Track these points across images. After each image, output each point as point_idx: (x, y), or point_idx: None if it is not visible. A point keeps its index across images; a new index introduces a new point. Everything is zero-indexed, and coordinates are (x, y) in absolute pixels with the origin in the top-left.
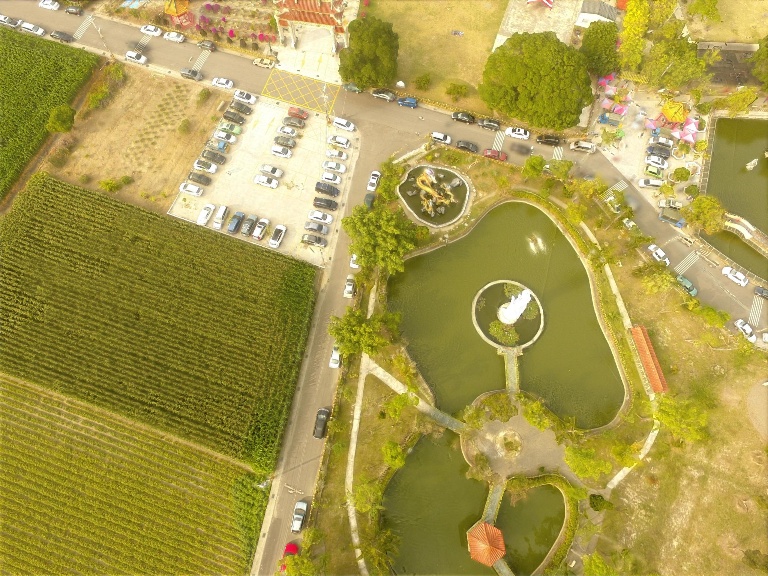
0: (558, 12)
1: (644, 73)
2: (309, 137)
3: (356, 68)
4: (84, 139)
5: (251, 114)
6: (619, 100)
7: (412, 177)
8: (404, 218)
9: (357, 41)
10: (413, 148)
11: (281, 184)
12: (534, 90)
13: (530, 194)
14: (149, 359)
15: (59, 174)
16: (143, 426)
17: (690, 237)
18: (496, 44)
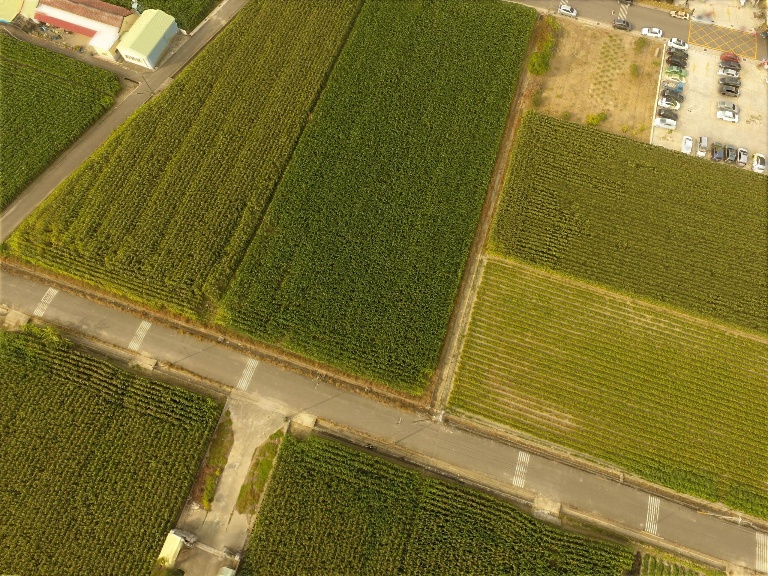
0: None
1: None
2: (746, 79)
3: None
4: (546, 82)
5: (687, 59)
6: None
7: None
8: None
9: None
10: None
11: (739, 119)
12: None
13: None
14: (694, 266)
15: (539, 112)
16: (704, 323)
17: None
18: None
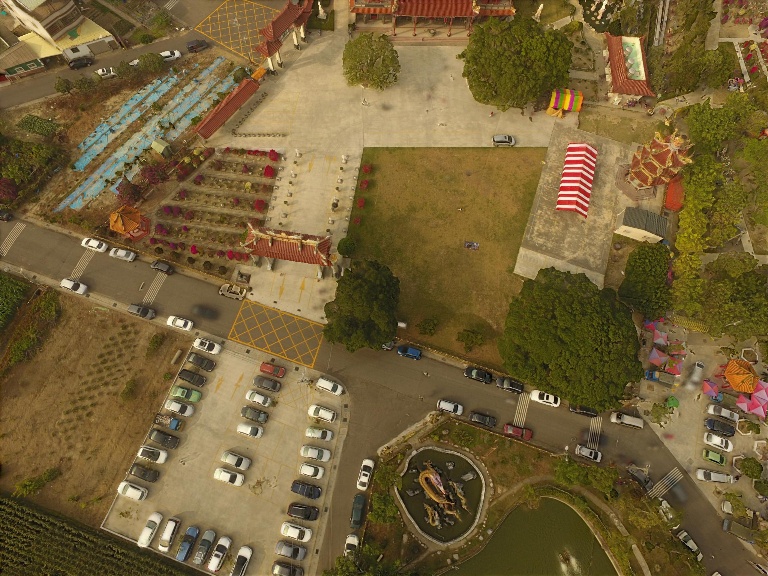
0: (593, 214)
1: (702, 318)
2: (286, 404)
3: (345, 334)
4: (2, 407)
5: (214, 369)
6: (671, 353)
7: (414, 468)
8: (403, 529)
9: (347, 301)
10: (415, 420)
11: (248, 478)
12: (570, 371)
13: (561, 492)
14: None
15: None
16: None
17: (764, 562)
18: (519, 262)
